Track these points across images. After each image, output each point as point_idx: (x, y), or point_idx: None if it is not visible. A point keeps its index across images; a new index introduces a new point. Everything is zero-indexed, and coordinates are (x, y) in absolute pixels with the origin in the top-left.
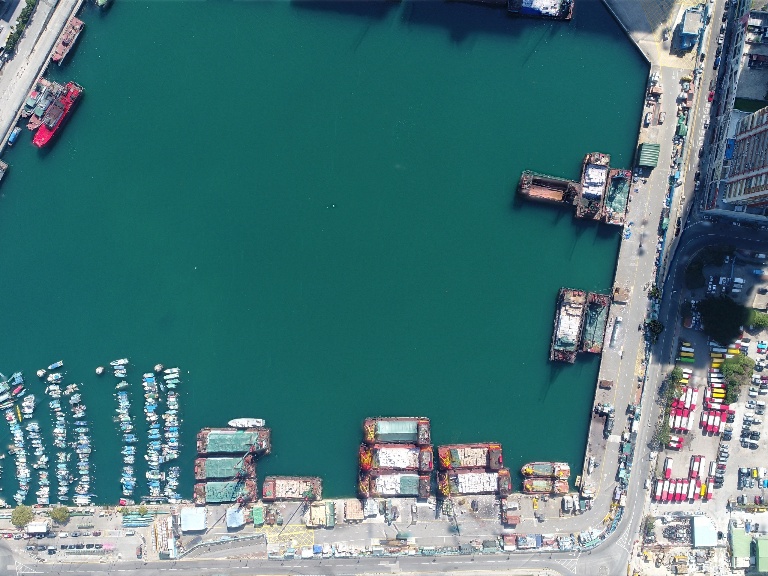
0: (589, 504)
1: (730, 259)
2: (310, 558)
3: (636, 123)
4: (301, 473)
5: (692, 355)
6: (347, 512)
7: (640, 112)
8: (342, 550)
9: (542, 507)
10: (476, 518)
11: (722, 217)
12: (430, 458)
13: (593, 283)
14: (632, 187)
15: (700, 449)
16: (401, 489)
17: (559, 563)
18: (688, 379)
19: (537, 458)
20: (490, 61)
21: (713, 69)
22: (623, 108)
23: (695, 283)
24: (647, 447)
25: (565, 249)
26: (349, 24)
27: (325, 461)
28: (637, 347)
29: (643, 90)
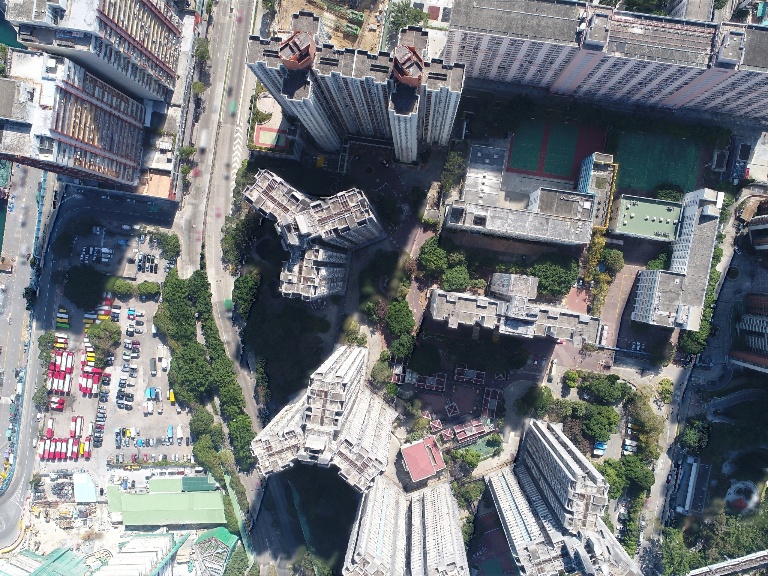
0: None
1: (101, 230)
2: None
3: None
4: None
5: (66, 321)
6: None
7: None
8: None
9: None
10: None
11: (94, 191)
12: None
13: None
14: None
15: (81, 410)
16: None
17: None
18: (68, 344)
19: None
20: None
21: None
22: None
23: (58, 252)
24: (35, 408)
25: None
26: None
27: None
28: (23, 314)
29: None
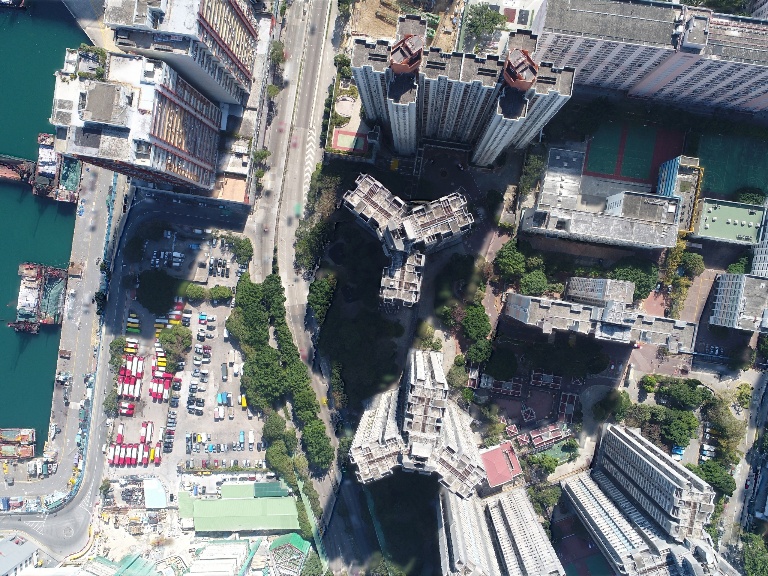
0: (51, 468)
1: (172, 234)
2: None
3: None
4: None
5: (137, 326)
6: None
7: None
8: None
9: (12, 471)
10: None
11: (165, 195)
12: None
13: (55, 258)
14: (84, 166)
15: (151, 415)
16: None
17: (28, 525)
18: (138, 349)
19: (7, 425)
20: None
21: None
22: None
23: (130, 257)
24: (104, 414)
25: (30, 225)
26: None
27: None
28: (92, 318)
29: None
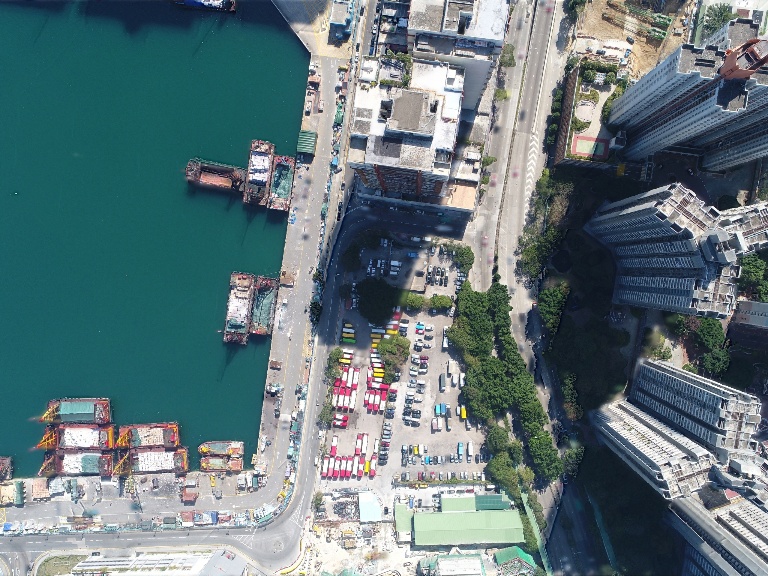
0: (262, 481)
1: (388, 243)
2: (2, 535)
3: (300, 111)
4: None
5: (353, 336)
6: (33, 490)
7: (304, 101)
8: (29, 527)
9: (219, 484)
10: (157, 496)
11: (380, 202)
12: (107, 437)
13: (264, 267)
14: (296, 173)
15: (365, 427)
16: (83, 468)
17: (236, 539)
18: (352, 359)
19: (214, 437)
20: (161, 52)
21: None
22: (287, 97)
23: (349, 266)
24: (316, 426)
25: (237, 234)
26: (28, 17)
27: (15, 441)
28: (304, 329)
29: (307, 79)
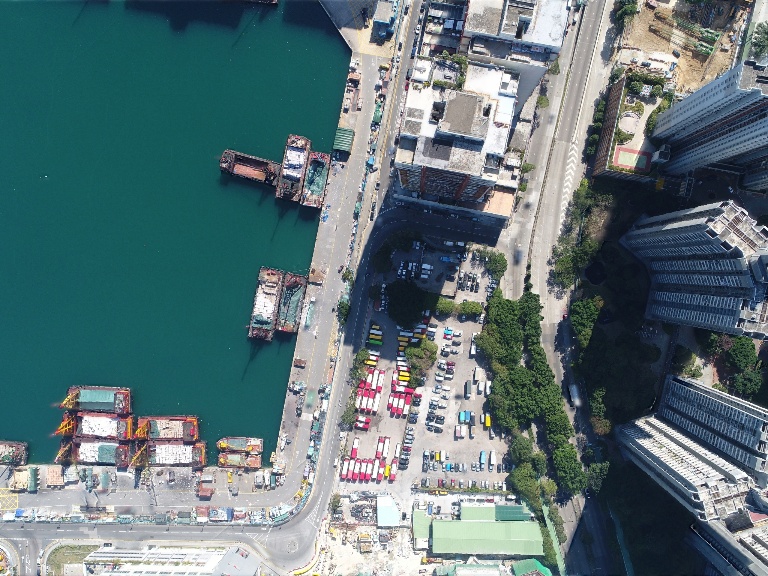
0: (279, 480)
1: (420, 245)
2: (13, 521)
3: (338, 108)
4: (9, 438)
5: (380, 338)
6: (47, 477)
7: None
8: (41, 515)
9: (236, 481)
10: (173, 489)
11: (415, 204)
12: (125, 427)
13: (293, 263)
14: (331, 171)
15: (387, 431)
16: (99, 457)
17: (250, 537)
18: (378, 361)
19: (234, 433)
20: (201, 41)
21: (410, 58)
22: (326, 93)
23: (380, 267)
24: (338, 426)
25: (268, 229)
26: None
27: (32, 427)
28: (331, 328)
29: (346, 76)
